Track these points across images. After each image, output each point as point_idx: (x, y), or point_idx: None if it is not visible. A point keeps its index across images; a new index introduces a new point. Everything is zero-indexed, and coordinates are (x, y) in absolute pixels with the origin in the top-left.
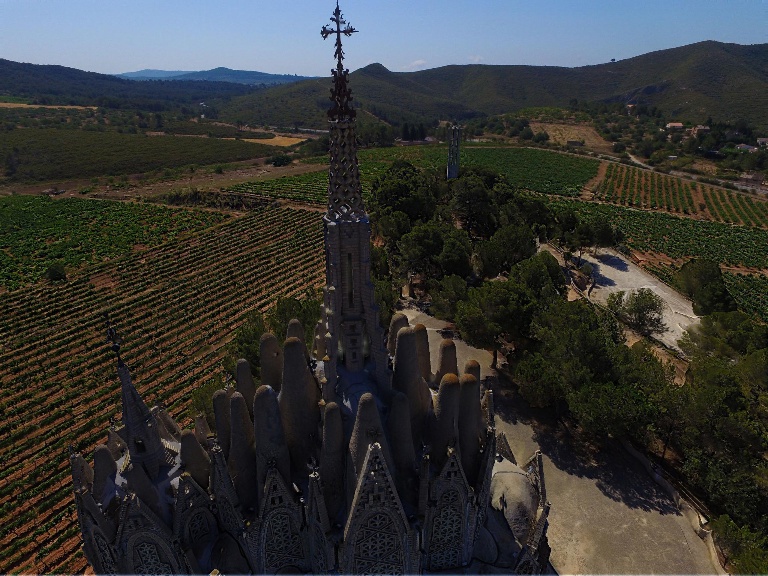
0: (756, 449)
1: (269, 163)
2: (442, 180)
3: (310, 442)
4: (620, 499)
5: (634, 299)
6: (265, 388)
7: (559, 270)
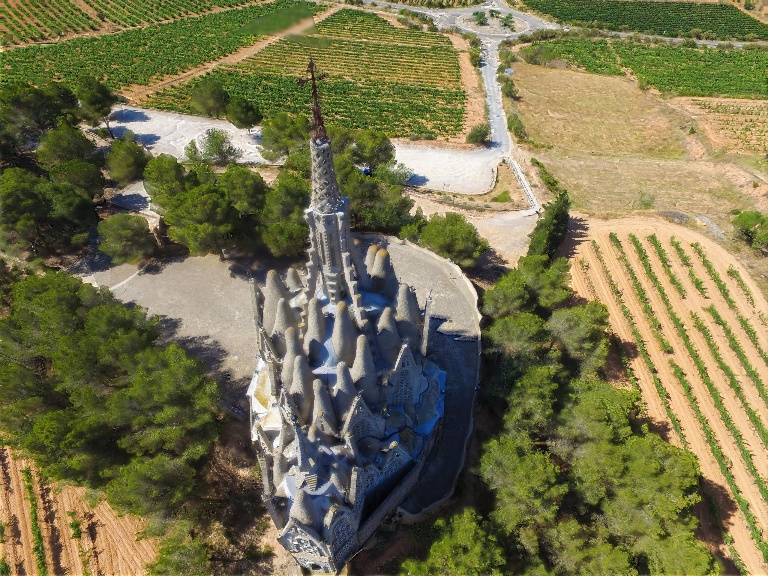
0: (373, 189)
1: None
2: None
3: None
4: None
5: (207, 142)
6: (364, 337)
7: (143, 152)
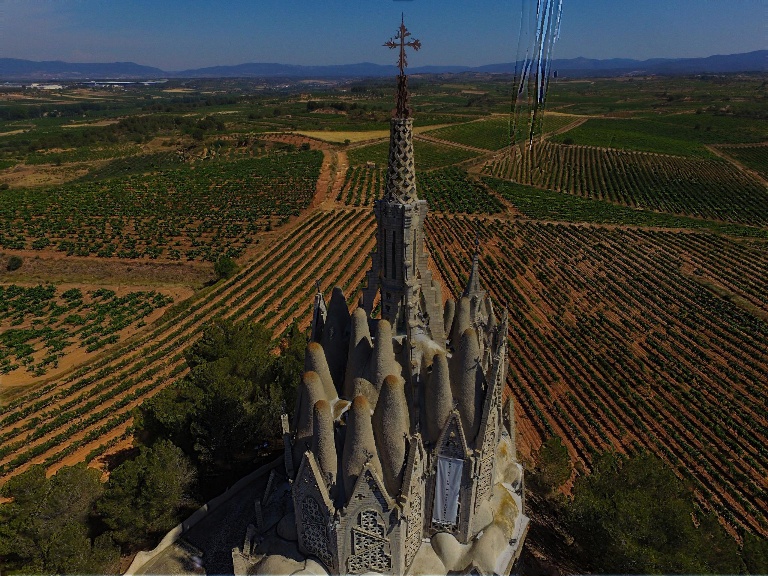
0: None
1: None
2: None
3: None
4: None
5: None
6: None
7: None
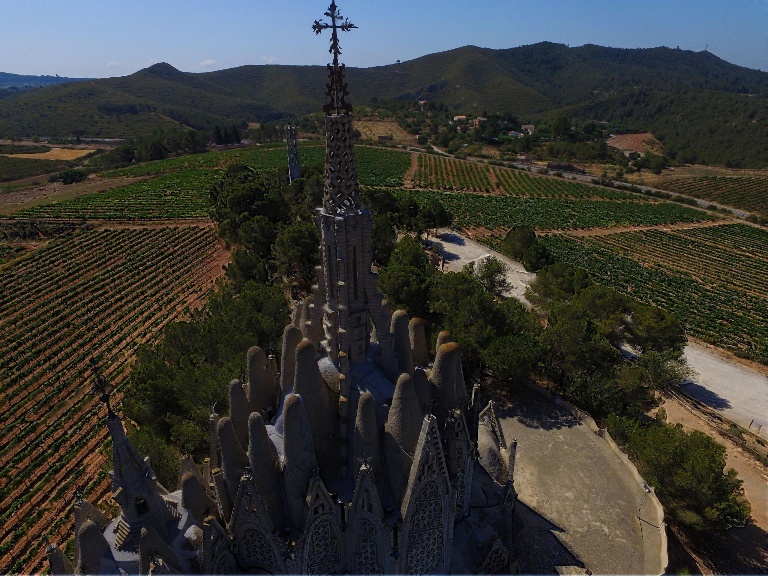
0: None
1: (55, 181)
2: (284, 181)
3: (331, 443)
4: (539, 426)
5: (484, 266)
6: (295, 397)
7: None
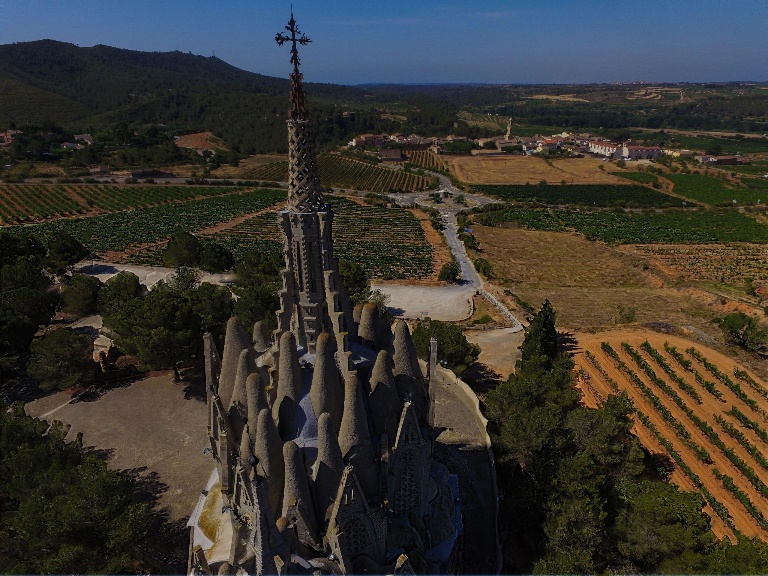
0: None
1: None
2: None
3: None
4: None
5: (176, 281)
6: (354, 377)
7: None
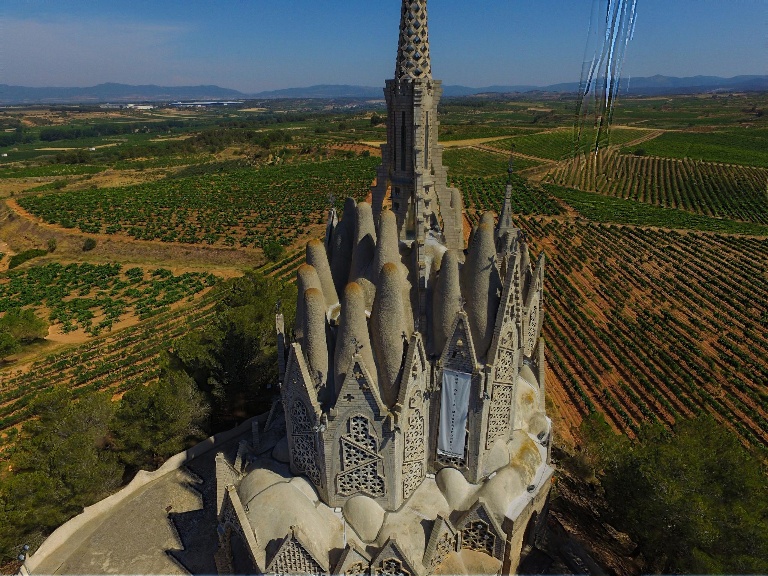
0: None
1: None
2: None
3: None
4: None
5: None
6: None
7: None
